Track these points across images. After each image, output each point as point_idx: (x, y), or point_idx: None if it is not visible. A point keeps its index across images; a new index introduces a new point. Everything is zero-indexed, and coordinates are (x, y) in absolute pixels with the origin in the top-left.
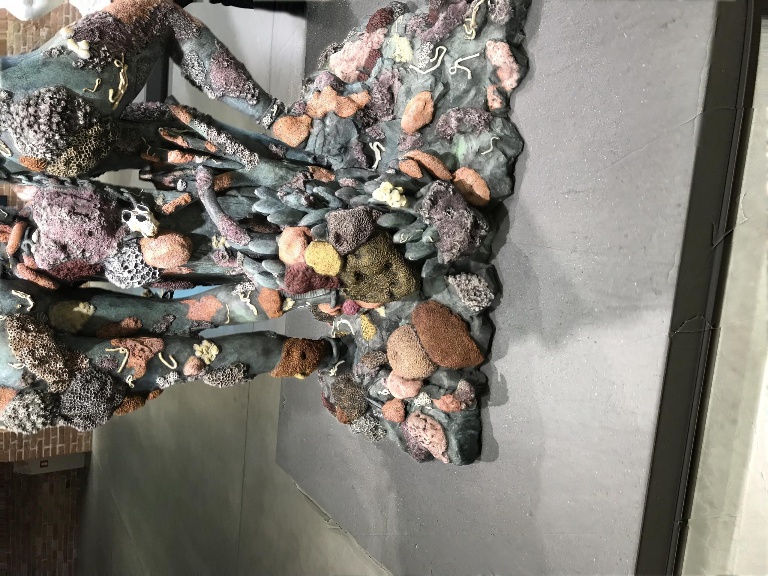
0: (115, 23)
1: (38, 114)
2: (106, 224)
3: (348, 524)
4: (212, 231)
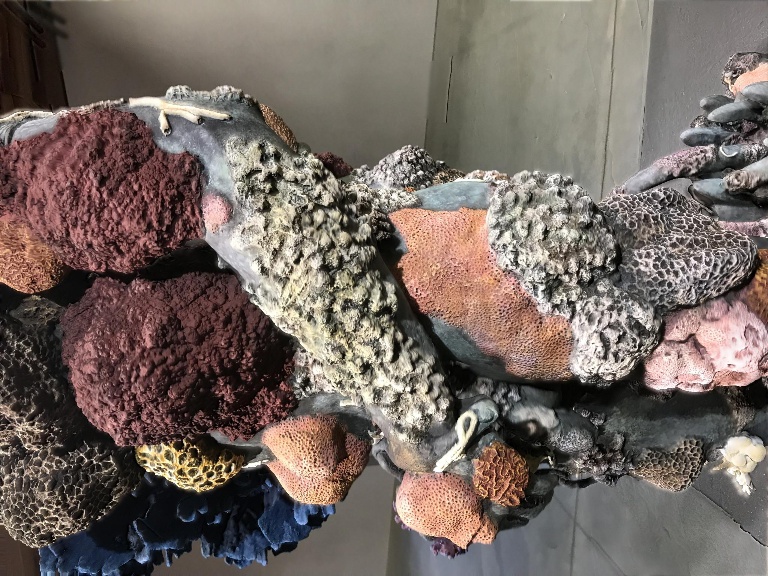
0: None
1: None
2: None
3: None
4: None
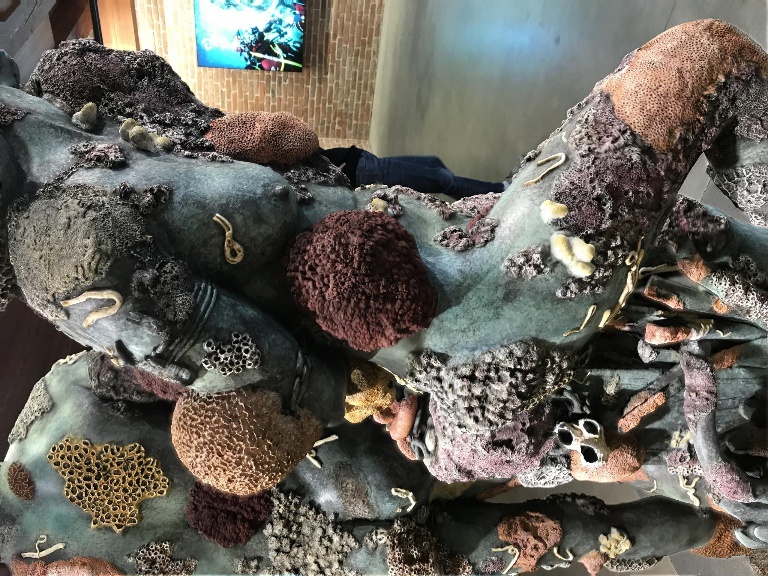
0: (641, 162)
1: (485, 392)
2: (533, 450)
3: (685, 572)
4: (676, 422)
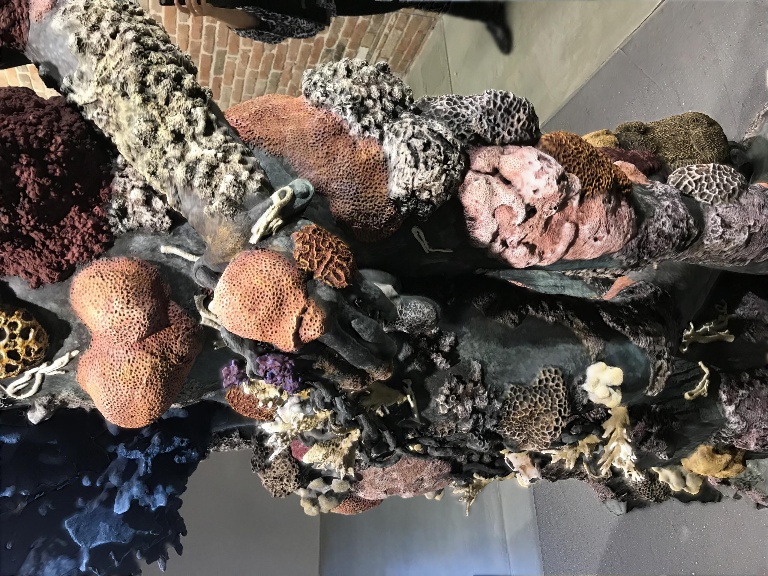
0: None
1: None
2: None
3: None
4: None
